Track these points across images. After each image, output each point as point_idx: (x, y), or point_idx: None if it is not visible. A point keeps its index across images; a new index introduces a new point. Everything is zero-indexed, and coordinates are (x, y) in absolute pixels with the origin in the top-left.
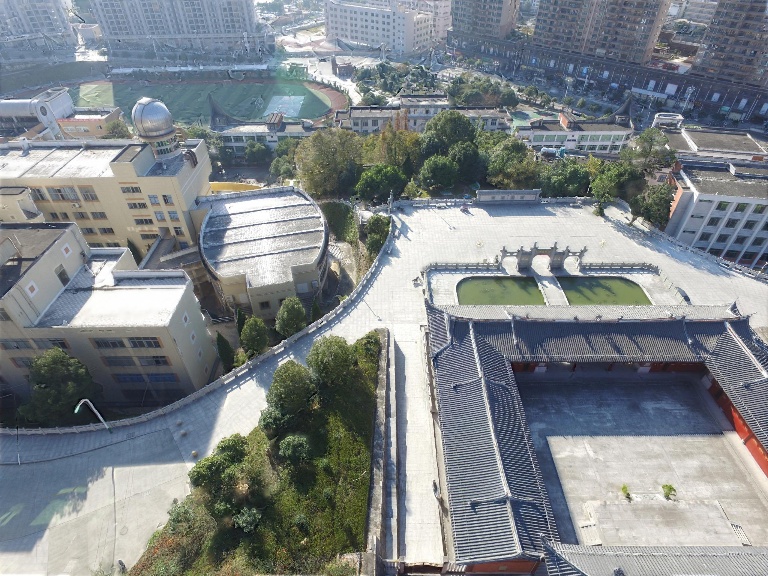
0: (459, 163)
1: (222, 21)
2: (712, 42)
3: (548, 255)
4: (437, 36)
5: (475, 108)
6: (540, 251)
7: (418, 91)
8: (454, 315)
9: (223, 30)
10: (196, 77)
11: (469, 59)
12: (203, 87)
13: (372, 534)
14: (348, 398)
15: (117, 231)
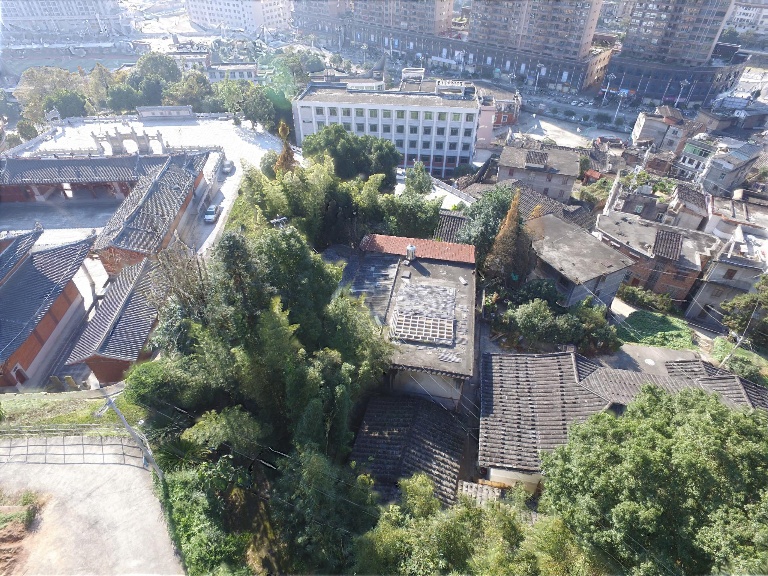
0: (144, 91)
1: (74, 3)
2: (477, 11)
3: (133, 140)
4: (286, 17)
5: (238, 64)
6: (124, 136)
7: (182, 48)
8: None
9: (77, 12)
10: (38, 54)
11: (305, 36)
12: (41, 62)
13: None
14: None
15: None
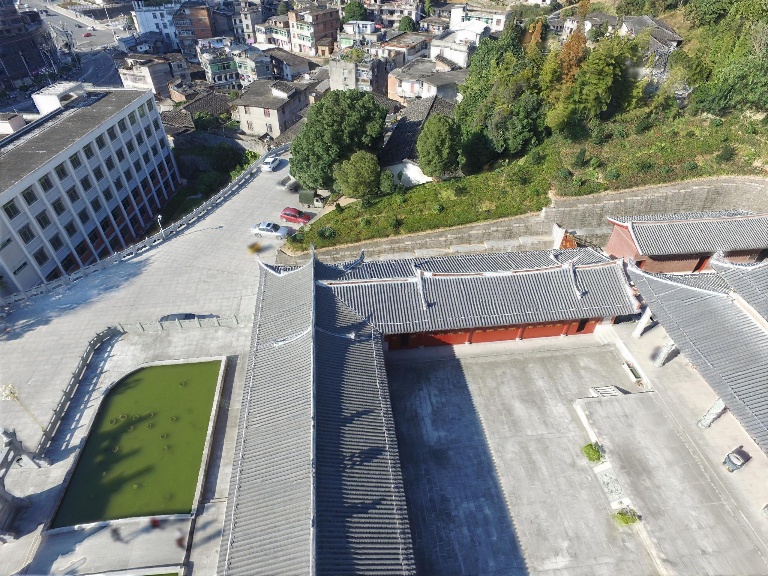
0: None
1: None
2: None
3: None
4: None
5: None
6: None
7: None
8: None
9: None
10: None
11: None
12: None
13: None
14: None
15: None
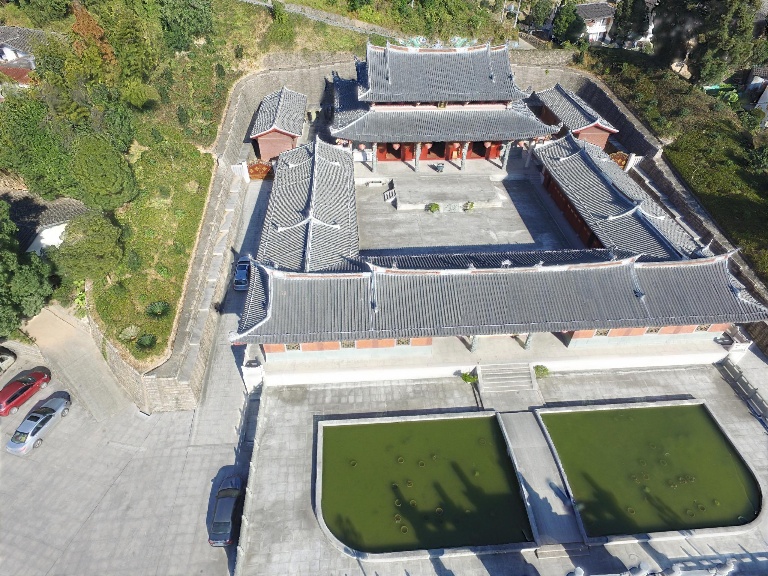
0: None
1: None
2: None
3: None
4: None
5: None
6: None
7: None
8: (720, 284)
9: None
10: None
11: None
12: None
13: (660, 160)
14: (760, 216)
15: None
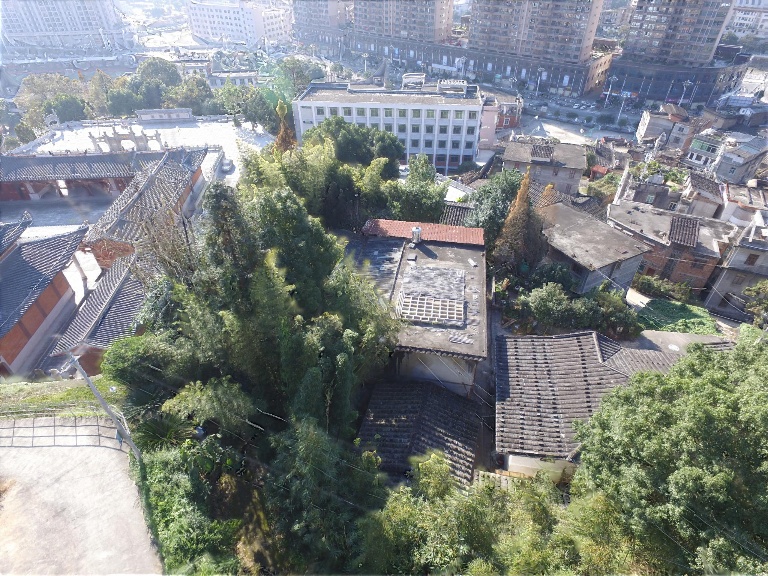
0: (144, 95)
1: (78, 19)
2: (477, 18)
3: (131, 140)
4: (287, 30)
5: (239, 71)
6: (122, 136)
7: (183, 57)
8: None
9: (81, 28)
10: (42, 68)
11: None
12: None
13: None
14: None
15: None
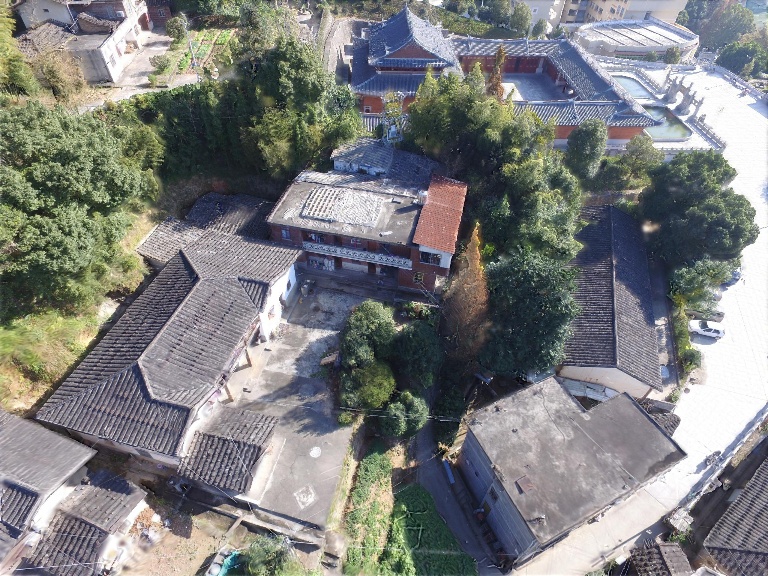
0: None
1: None
2: None
3: None
4: None
5: None
6: (682, 88)
7: None
8: None
9: None
10: None
11: None
12: None
13: None
14: None
15: (603, 13)
